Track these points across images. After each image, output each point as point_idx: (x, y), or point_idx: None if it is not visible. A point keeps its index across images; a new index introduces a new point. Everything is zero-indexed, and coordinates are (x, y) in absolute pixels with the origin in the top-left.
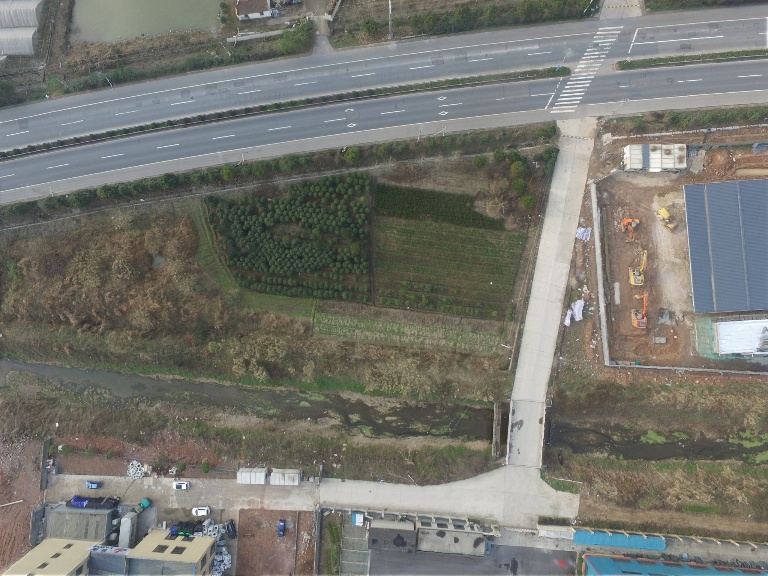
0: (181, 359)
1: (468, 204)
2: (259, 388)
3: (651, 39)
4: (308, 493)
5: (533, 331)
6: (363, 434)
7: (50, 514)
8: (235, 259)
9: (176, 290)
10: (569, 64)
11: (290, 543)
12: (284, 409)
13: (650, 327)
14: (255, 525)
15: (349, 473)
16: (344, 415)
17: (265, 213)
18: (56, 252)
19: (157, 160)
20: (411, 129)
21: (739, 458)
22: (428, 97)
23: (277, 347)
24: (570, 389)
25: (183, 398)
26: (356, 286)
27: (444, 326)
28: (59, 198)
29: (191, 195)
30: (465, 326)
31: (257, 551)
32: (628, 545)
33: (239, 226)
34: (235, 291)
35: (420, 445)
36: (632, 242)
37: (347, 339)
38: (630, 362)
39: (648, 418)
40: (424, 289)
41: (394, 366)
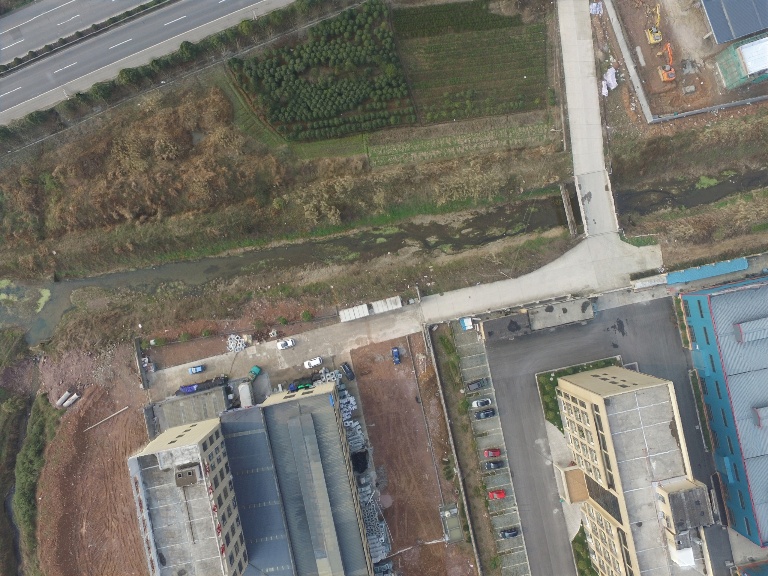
0: (250, 223)
1: (484, 6)
2: (332, 237)
3: None
4: (411, 316)
5: (577, 108)
6: (445, 253)
7: (163, 406)
8: (276, 111)
9: (225, 157)
10: None
11: (408, 368)
12: (362, 251)
13: (677, 80)
14: (369, 361)
15: (445, 286)
16: (422, 240)
17: (293, 60)
18: (90, 152)
19: (168, 37)
20: None
21: None
22: None
23: (344, 181)
24: (624, 152)
25: (260, 268)
26: (401, 110)
27: (493, 128)
28: (77, 99)
29: (212, 64)
30: (512, 123)
31: (378, 385)
32: (716, 273)
33: (271, 79)
34: (283, 147)
35: (501, 248)
36: (641, 7)
37: (405, 164)
38: (669, 114)
39: (697, 165)
40: (466, 96)
41: (458, 175)
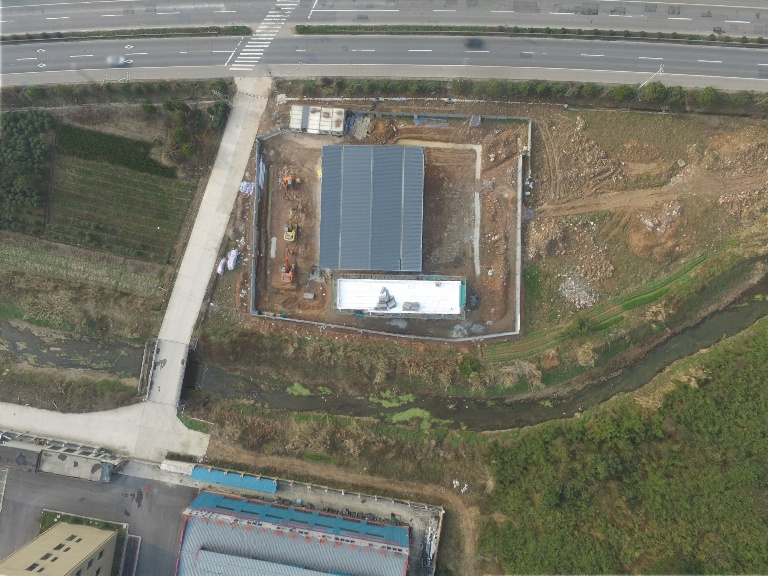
0: None
1: (141, 150)
2: None
3: (331, 7)
4: None
5: (186, 276)
6: (27, 362)
7: None
8: None
9: None
10: (251, 24)
11: None
12: None
13: (301, 283)
14: None
15: None
16: (12, 342)
17: None
18: None
19: None
20: (97, 74)
21: (377, 416)
22: (116, 44)
23: None
24: (214, 334)
25: None
26: (28, 218)
27: (108, 264)
28: None
29: None
30: (128, 266)
31: None
32: (241, 485)
33: None
34: None
35: (79, 377)
36: (293, 200)
37: (17, 269)
38: (275, 314)
39: (294, 370)
40: (91, 227)
41: None
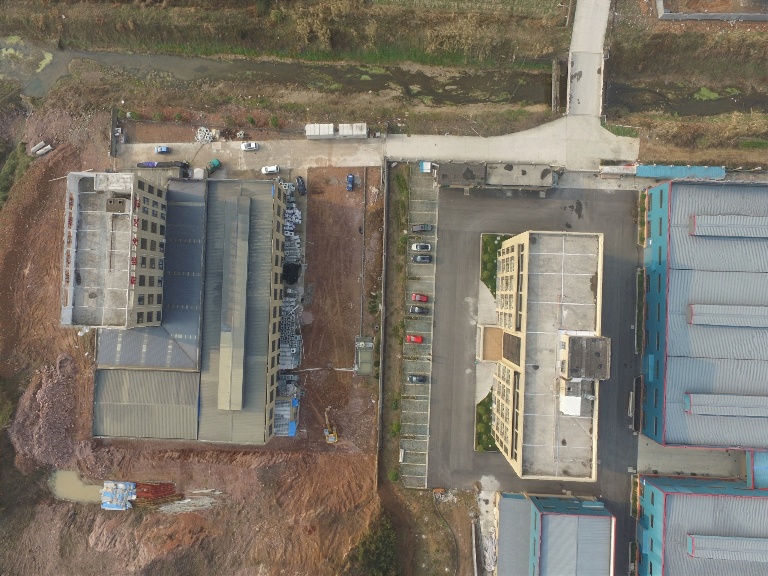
0: (244, 28)
1: None
2: (320, 64)
3: None
4: (375, 149)
5: None
6: (424, 104)
7: (122, 171)
8: None
9: None
10: None
11: (359, 198)
12: (345, 83)
13: None
14: (324, 182)
15: (414, 128)
16: (405, 86)
17: None
18: None
19: None
20: None
21: None
22: None
23: (340, 4)
24: (626, 40)
25: (245, 77)
26: None
27: None
28: None
29: None
30: None
31: (326, 207)
32: (689, 175)
33: None
34: None
35: (480, 111)
36: None
37: (406, 8)
38: None
39: (701, 75)
40: None
41: (454, 27)
